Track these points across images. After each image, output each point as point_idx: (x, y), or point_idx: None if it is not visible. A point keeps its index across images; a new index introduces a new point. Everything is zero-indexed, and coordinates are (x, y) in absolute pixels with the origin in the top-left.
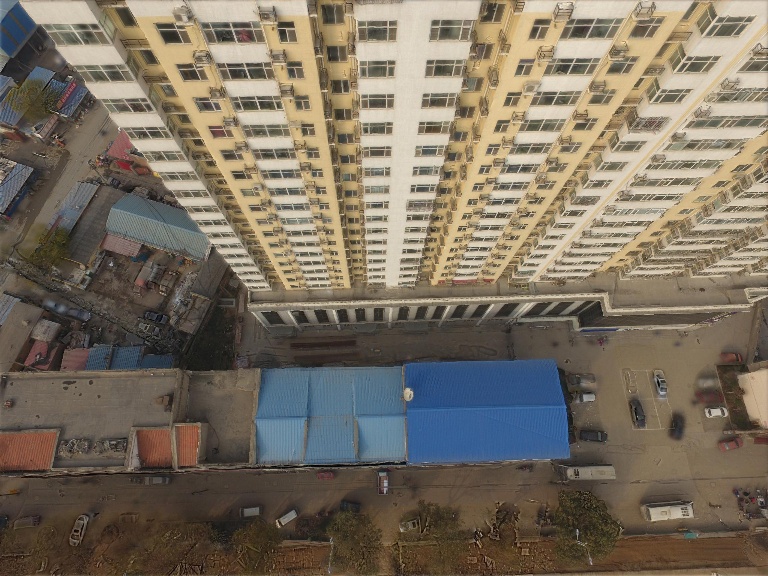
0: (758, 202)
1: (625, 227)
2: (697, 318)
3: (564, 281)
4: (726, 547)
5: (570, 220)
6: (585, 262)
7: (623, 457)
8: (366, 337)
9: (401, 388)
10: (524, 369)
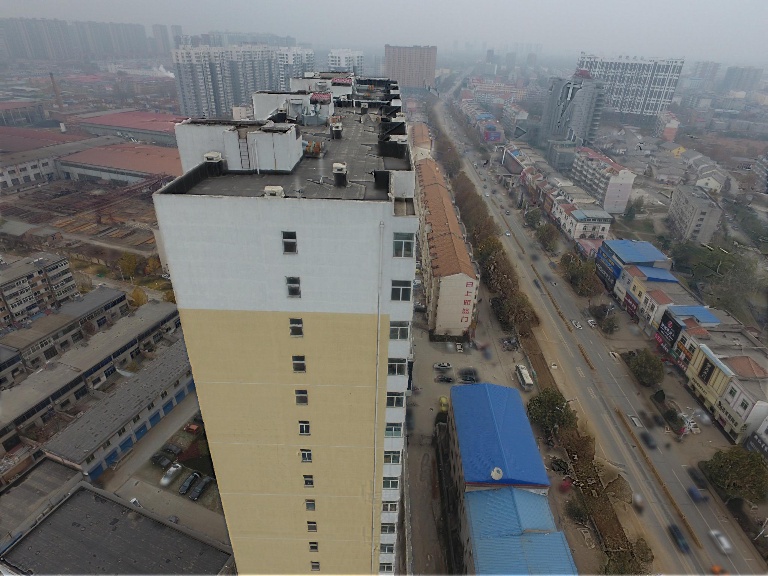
0: None
1: None
2: None
3: None
4: (535, 361)
5: None
6: None
7: None
8: (413, 571)
9: (486, 492)
10: None
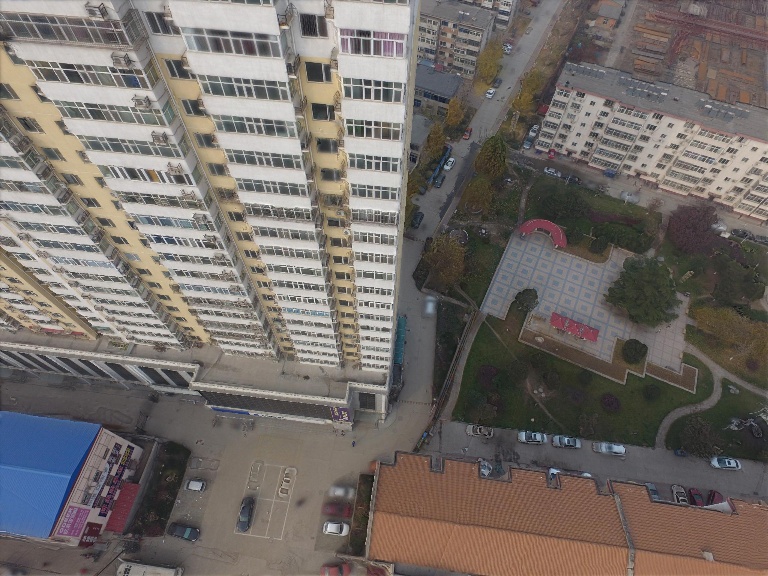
0: (192, 267)
1: (108, 282)
2: (317, 411)
3: (163, 347)
4: None
5: (33, 264)
6: (148, 324)
7: (207, 563)
8: (13, 384)
9: None
10: (64, 430)
